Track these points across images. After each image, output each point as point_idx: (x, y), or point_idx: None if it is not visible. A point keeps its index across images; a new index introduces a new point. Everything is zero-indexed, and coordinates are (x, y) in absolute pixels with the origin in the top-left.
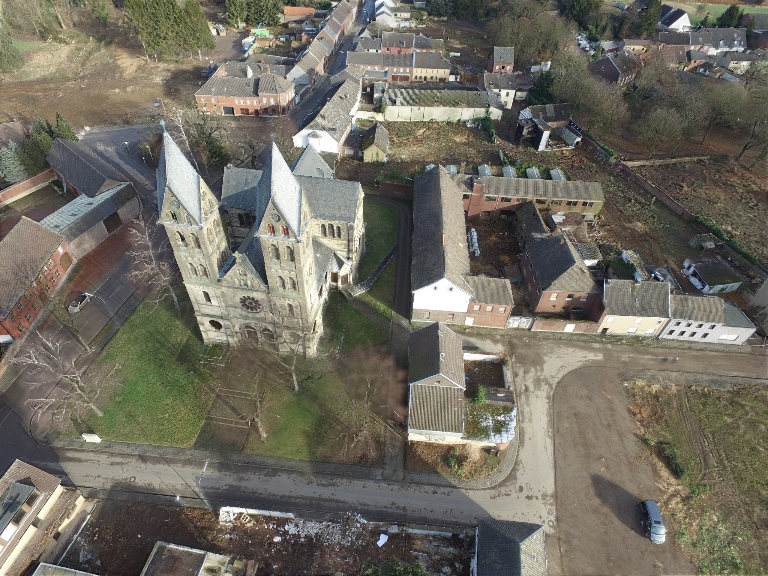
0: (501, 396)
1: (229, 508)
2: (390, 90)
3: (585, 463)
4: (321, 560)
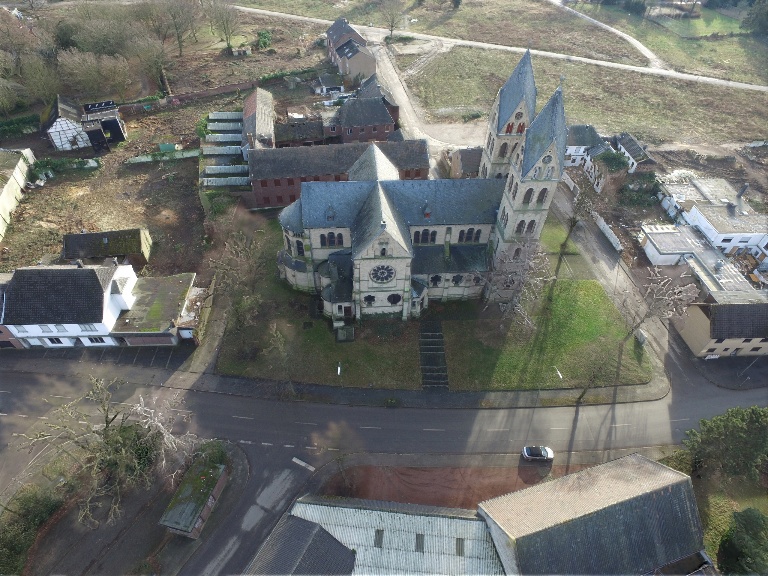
0: None
1: None
2: None
3: None
4: None
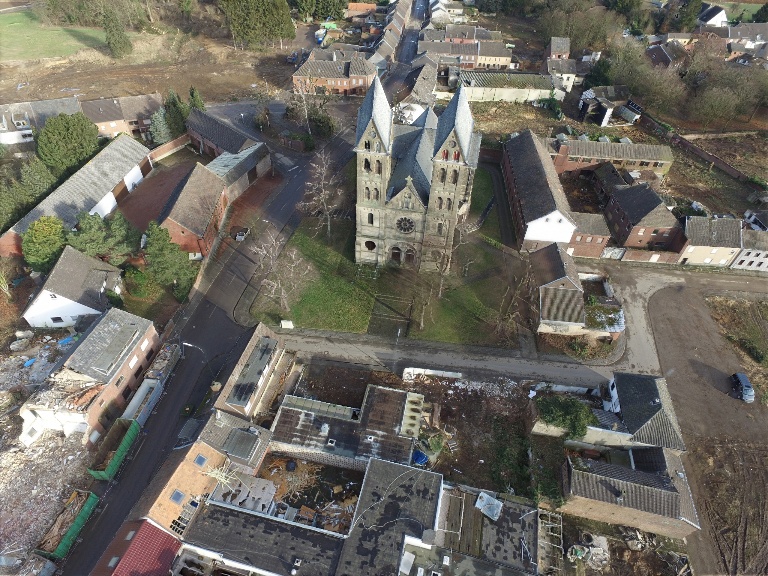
0: (609, 301)
1: (411, 369)
2: (464, 73)
3: (682, 351)
4: (487, 406)
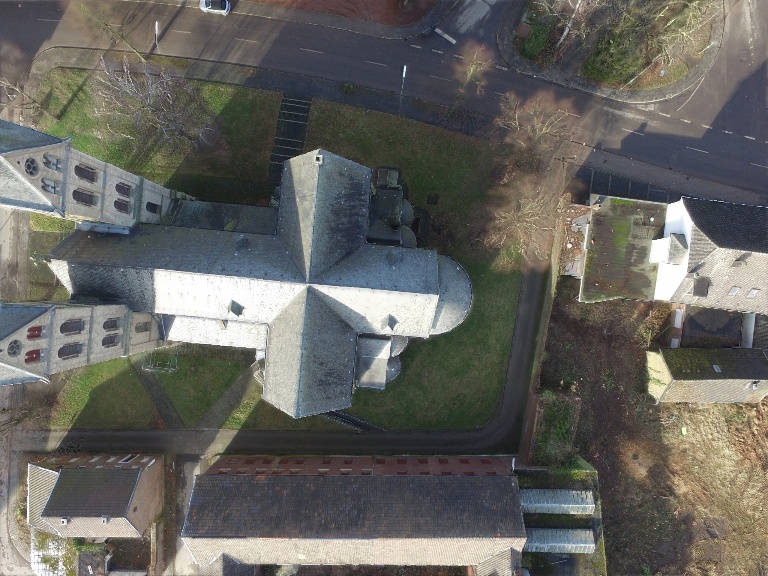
0: (88, 570)
1: None
2: None
3: None
4: None
